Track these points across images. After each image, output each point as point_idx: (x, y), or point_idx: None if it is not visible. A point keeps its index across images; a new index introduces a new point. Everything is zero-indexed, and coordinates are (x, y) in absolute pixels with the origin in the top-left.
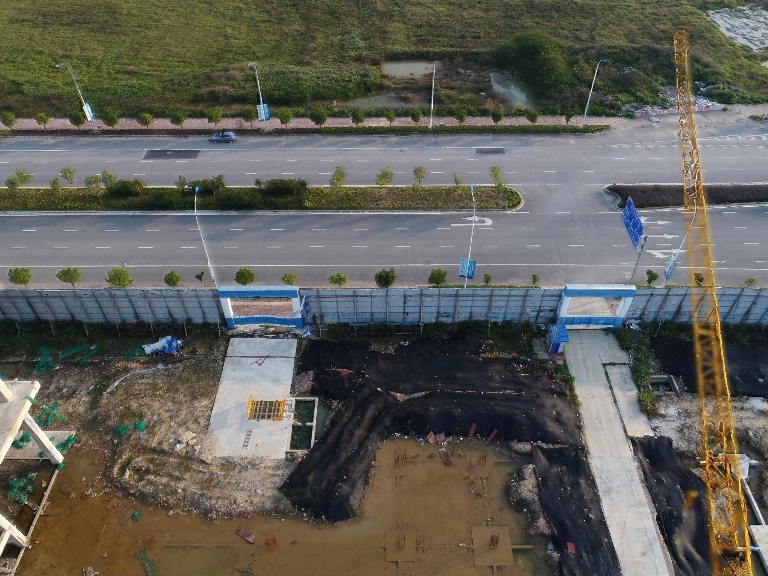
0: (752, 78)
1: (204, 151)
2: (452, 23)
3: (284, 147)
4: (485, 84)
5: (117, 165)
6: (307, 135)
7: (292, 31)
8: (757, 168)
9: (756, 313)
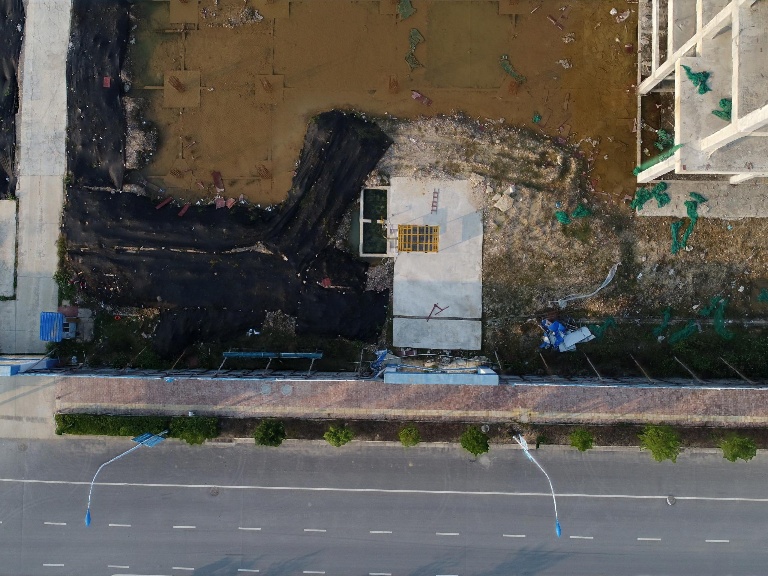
0: None
1: None
2: None
3: None
4: None
5: None
6: None
7: None
8: None
9: None
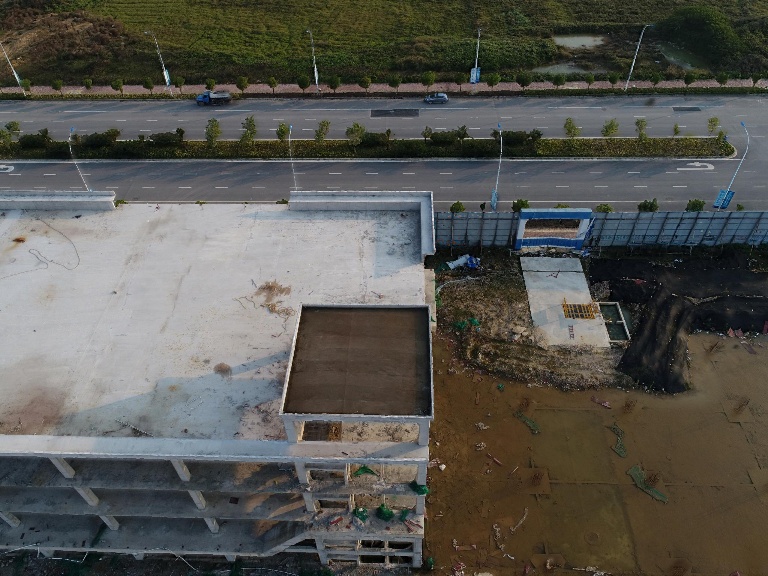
0: None
1: (422, 110)
2: (605, 1)
3: (494, 107)
4: (657, 53)
5: (349, 122)
6: (511, 97)
7: (454, 9)
8: None
9: None
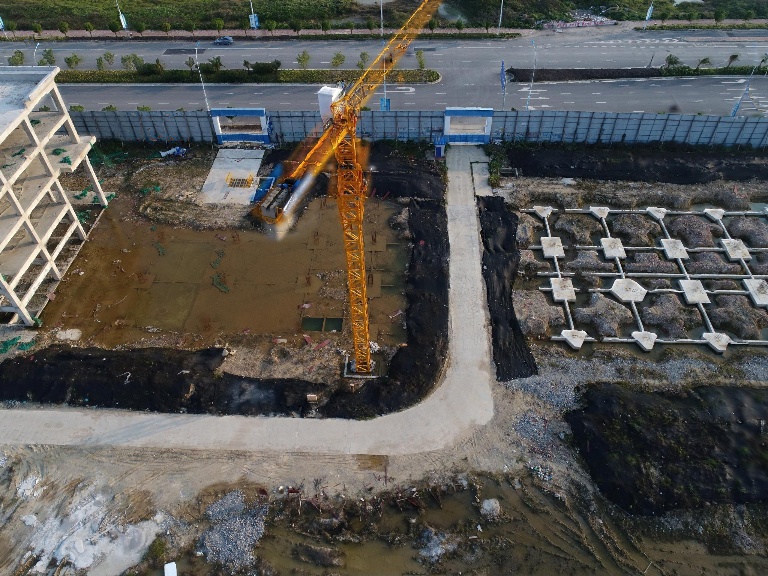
0: (645, 3)
1: (209, 50)
2: None
3: (269, 47)
4: (432, 9)
5: (144, 58)
6: (287, 40)
7: None
8: (624, 59)
9: (582, 133)
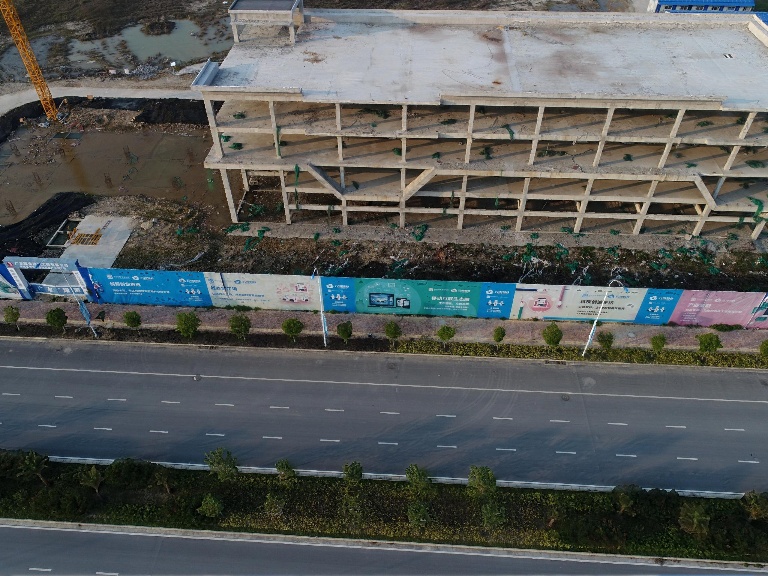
0: None
1: None
2: None
3: None
4: None
5: None
6: None
7: None
8: None
9: None
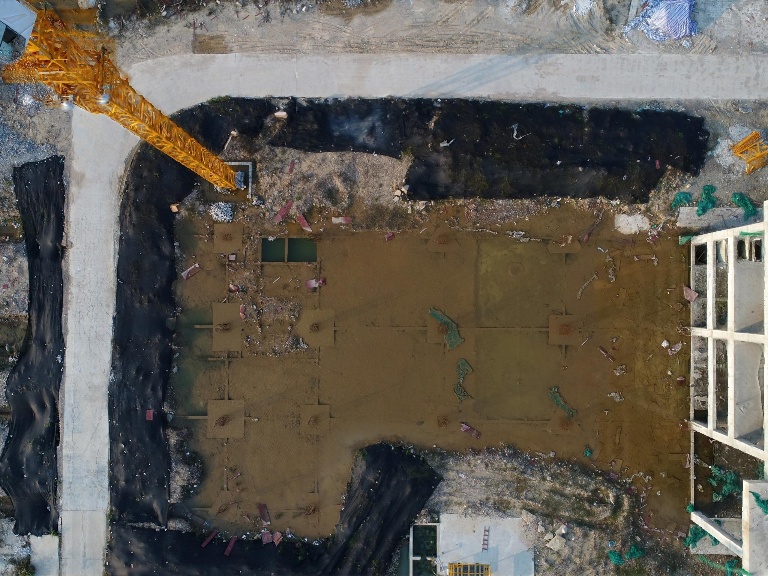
0: None
1: None
2: None
3: None
4: None
5: None
6: None
7: None
8: None
9: None
